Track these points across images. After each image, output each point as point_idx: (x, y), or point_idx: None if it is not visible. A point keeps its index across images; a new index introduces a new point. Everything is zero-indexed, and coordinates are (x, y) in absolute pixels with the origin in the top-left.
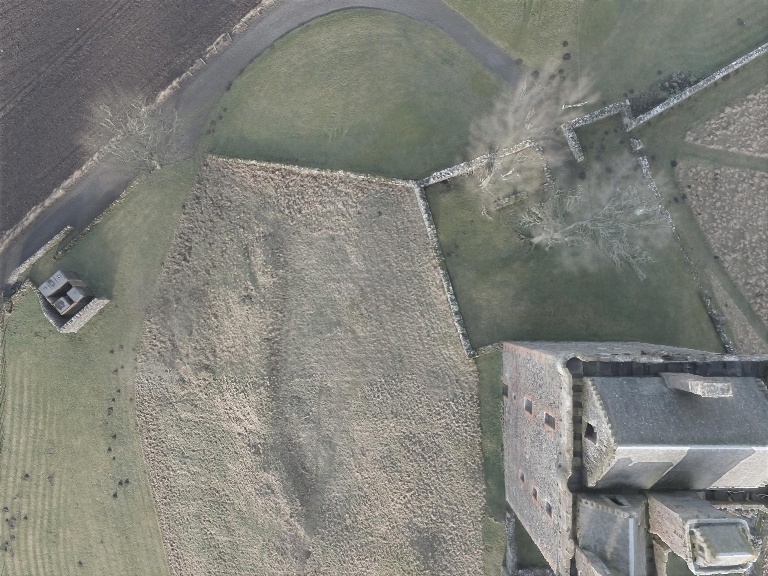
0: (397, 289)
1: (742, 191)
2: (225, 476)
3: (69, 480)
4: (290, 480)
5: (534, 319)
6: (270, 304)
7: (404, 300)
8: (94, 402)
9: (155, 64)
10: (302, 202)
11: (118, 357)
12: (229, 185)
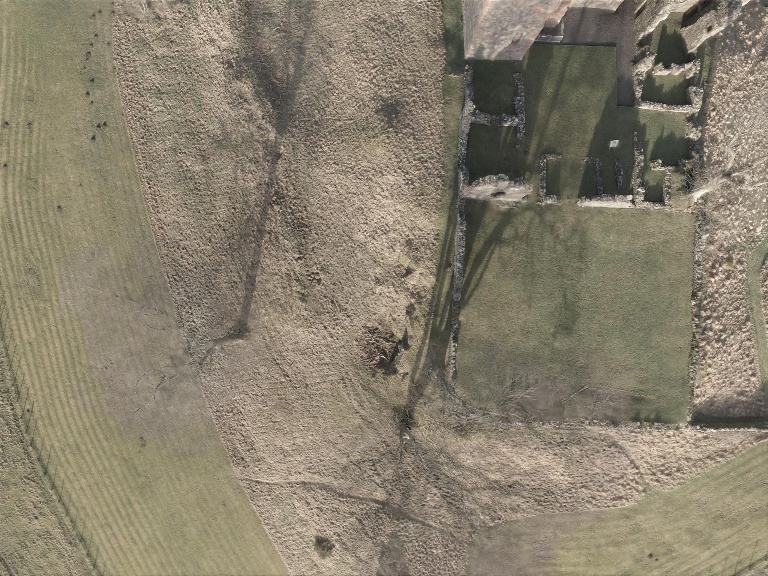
0: None
1: None
2: (200, 105)
3: (48, 126)
4: (262, 86)
5: None
6: None
7: None
8: (72, 47)
9: None
10: None
11: (96, 2)
12: None
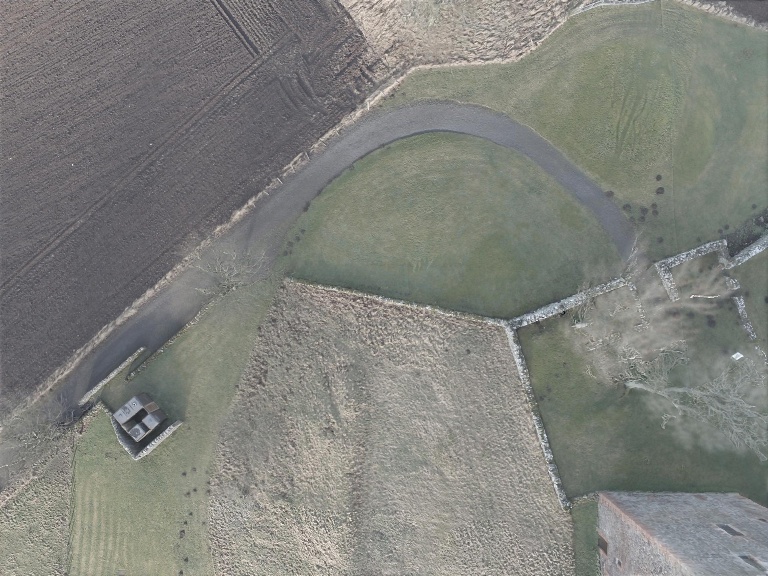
0: (487, 432)
1: None
2: None
3: None
4: None
5: (630, 468)
6: (353, 439)
7: (495, 444)
8: (166, 524)
9: (230, 182)
10: (385, 333)
11: (191, 479)
12: (307, 309)
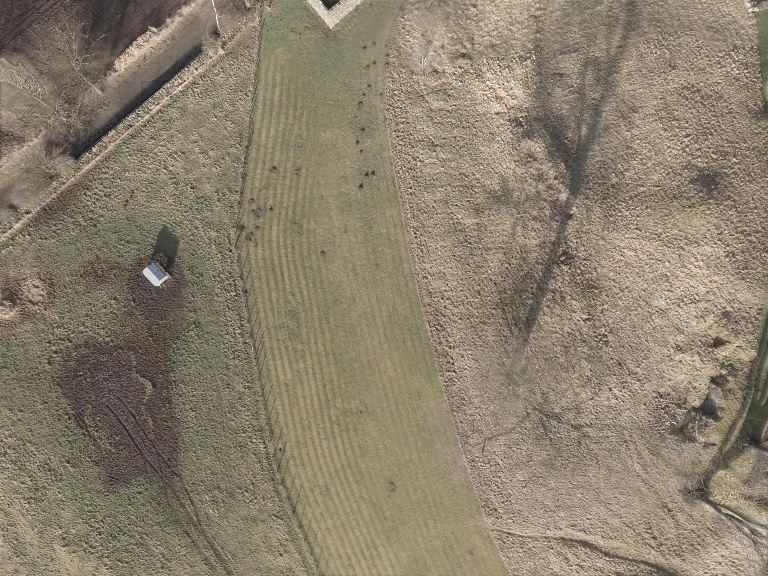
0: None
1: None
2: (477, 160)
3: (316, 172)
4: (554, 146)
5: None
6: None
7: None
8: (345, 96)
9: None
10: None
11: (370, 53)
12: None
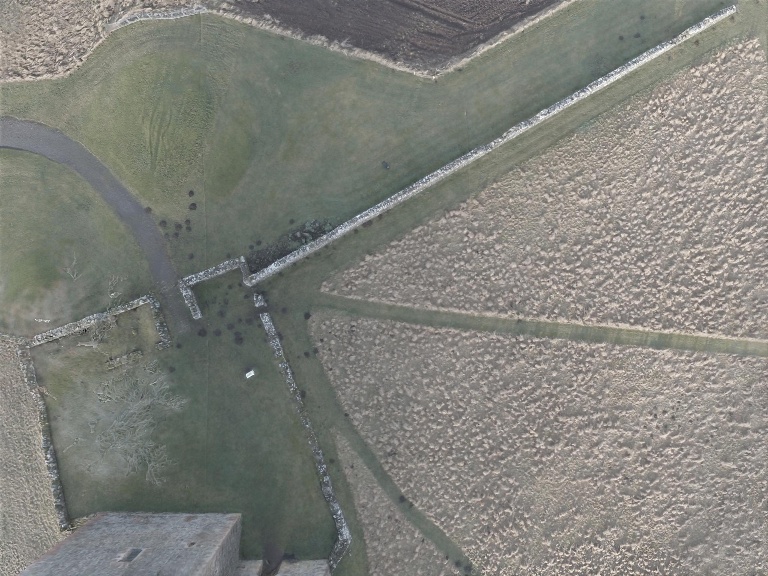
0: (5, 452)
1: (380, 343)
2: None
3: None
4: None
5: (135, 488)
6: None
7: (11, 464)
8: None
9: None
10: None
11: None
12: None
